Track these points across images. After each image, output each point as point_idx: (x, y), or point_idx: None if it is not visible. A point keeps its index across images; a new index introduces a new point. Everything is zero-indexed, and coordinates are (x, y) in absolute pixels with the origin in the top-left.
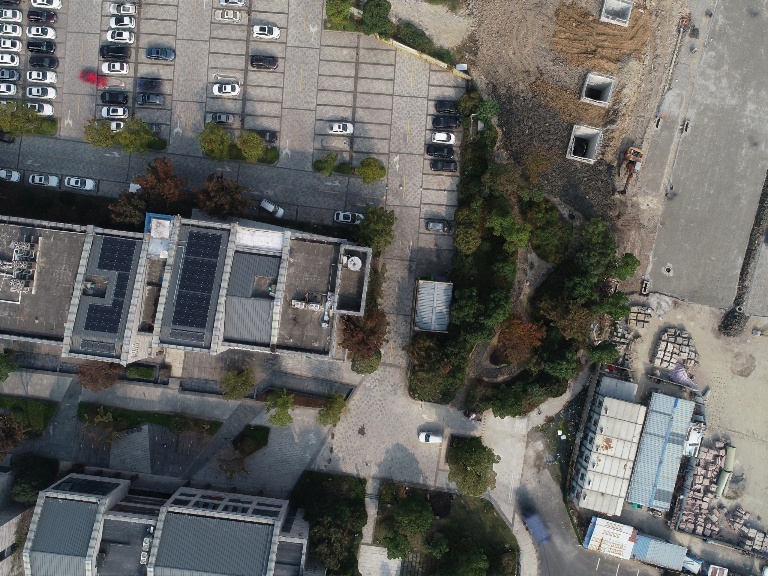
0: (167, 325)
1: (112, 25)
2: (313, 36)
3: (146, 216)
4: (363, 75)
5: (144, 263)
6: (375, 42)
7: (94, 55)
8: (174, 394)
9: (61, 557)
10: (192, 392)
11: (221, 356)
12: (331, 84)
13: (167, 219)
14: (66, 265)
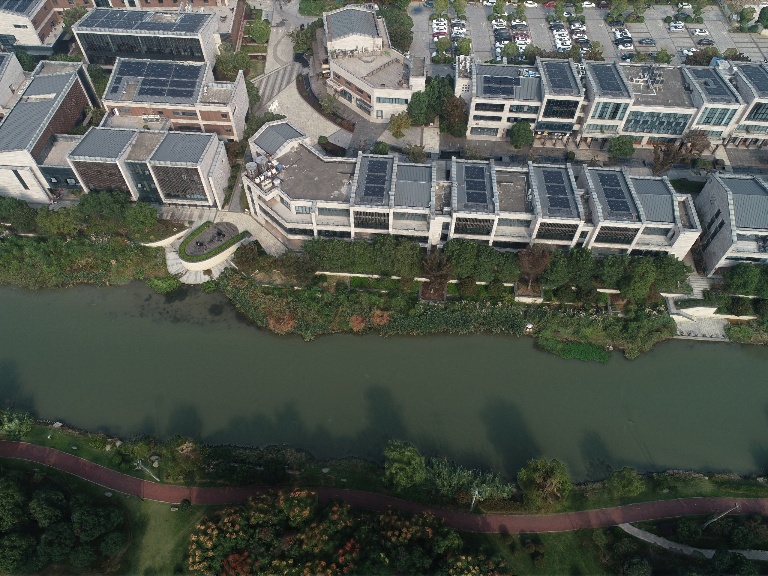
0: (757, 91)
1: (618, 33)
2: (725, 35)
3: (714, 58)
4: (761, 47)
5: (723, 74)
6: (760, 36)
7: (610, 45)
8: (731, 174)
9: (751, 197)
10: (743, 172)
11: (751, 155)
12: (746, 50)
13: (725, 60)
14: (675, 80)
